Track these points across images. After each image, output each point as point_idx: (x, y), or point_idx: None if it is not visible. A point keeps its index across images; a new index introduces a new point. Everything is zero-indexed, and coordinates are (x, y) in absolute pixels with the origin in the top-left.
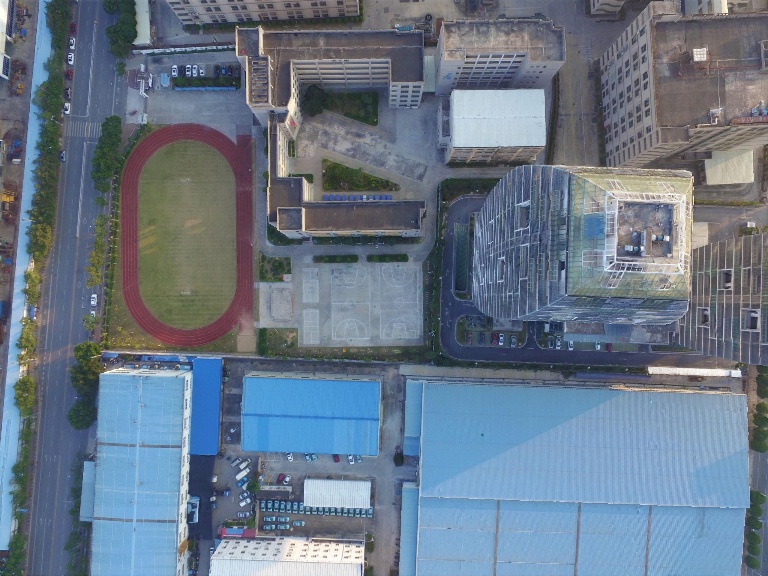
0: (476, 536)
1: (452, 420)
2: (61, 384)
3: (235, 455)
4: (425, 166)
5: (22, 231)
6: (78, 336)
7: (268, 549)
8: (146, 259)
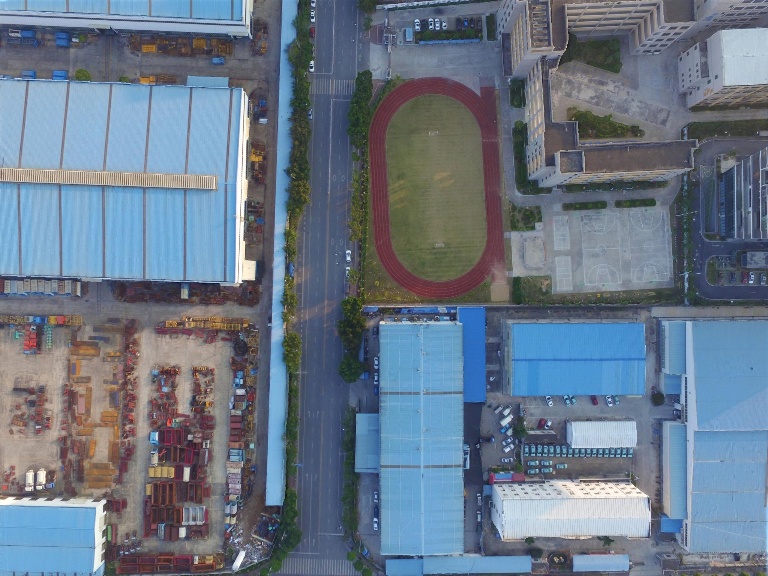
0: (748, 467)
1: (721, 356)
2: (320, 341)
3: (496, 403)
4: (668, 111)
5: (279, 189)
6: (334, 292)
7: (547, 490)
8: (397, 213)
